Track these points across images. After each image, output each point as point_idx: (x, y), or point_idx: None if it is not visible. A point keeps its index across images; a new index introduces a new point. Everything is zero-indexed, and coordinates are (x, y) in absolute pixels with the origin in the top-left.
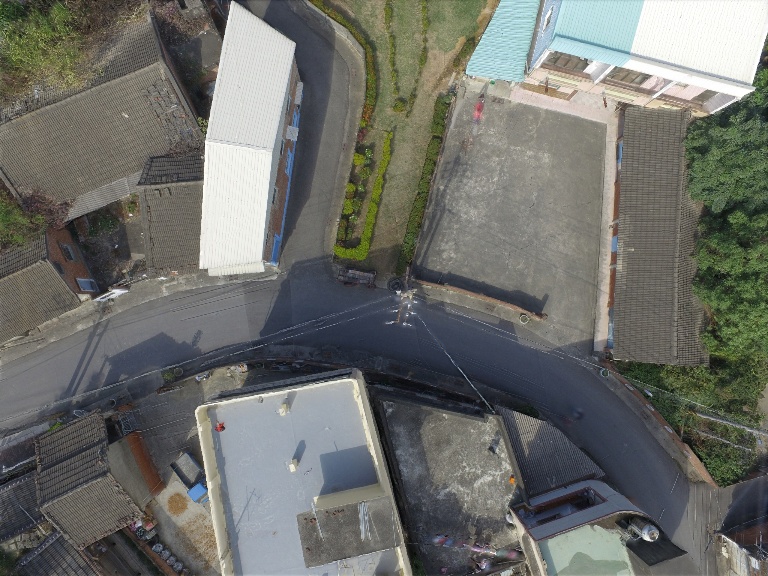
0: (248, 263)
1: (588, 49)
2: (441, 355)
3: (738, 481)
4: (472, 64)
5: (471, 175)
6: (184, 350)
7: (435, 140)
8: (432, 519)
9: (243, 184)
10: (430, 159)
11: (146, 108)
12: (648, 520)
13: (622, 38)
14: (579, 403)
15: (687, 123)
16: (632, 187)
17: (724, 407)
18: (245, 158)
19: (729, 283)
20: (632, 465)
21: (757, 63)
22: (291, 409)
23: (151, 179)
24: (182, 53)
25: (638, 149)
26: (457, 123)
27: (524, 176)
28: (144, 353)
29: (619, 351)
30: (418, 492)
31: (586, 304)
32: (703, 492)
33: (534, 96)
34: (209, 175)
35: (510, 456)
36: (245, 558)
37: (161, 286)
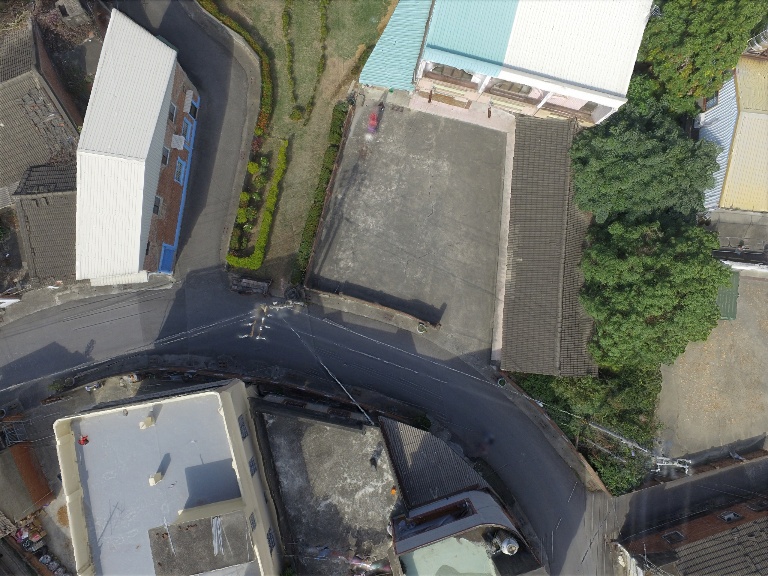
0: (125, 274)
1: (459, 60)
2: (338, 364)
3: (632, 490)
4: (365, 72)
5: (369, 184)
6: (77, 360)
7: (331, 148)
8: (312, 531)
9: (117, 194)
10: (326, 168)
11: (22, 117)
12: (510, 533)
13: (495, 49)
14: (477, 412)
15: (574, 133)
16: (521, 197)
17: (617, 417)
18: (118, 168)
19: (608, 294)
20: (529, 474)
21: (630, 74)
22: (156, 422)
23: (28, 189)
24: (66, 61)
25: (528, 159)
26: (356, 131)
27: (423, 185)
28: (36, 363)
29: (506, 361)
30: (298, 504)
31: (484, 313)
32: (600, 501)
33: (433, 104)
34: (82, 185)
35: (390, 467)
36: (107, 572)
37: (54, 295)
